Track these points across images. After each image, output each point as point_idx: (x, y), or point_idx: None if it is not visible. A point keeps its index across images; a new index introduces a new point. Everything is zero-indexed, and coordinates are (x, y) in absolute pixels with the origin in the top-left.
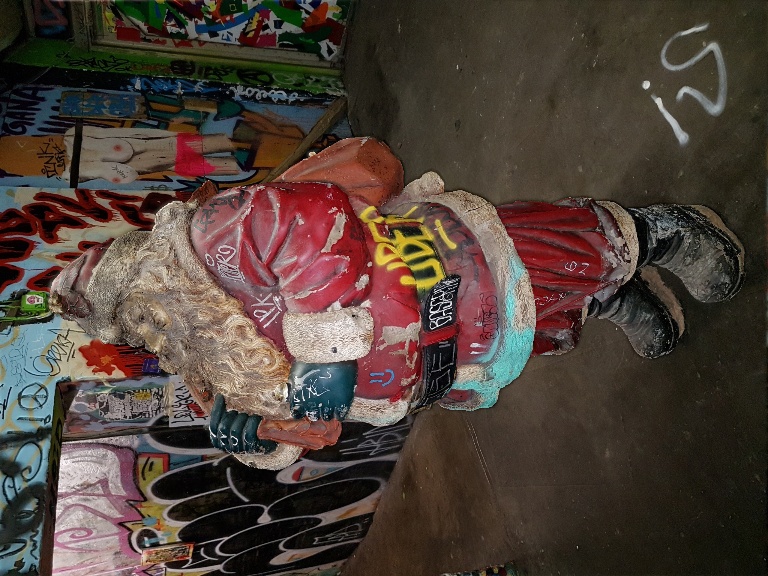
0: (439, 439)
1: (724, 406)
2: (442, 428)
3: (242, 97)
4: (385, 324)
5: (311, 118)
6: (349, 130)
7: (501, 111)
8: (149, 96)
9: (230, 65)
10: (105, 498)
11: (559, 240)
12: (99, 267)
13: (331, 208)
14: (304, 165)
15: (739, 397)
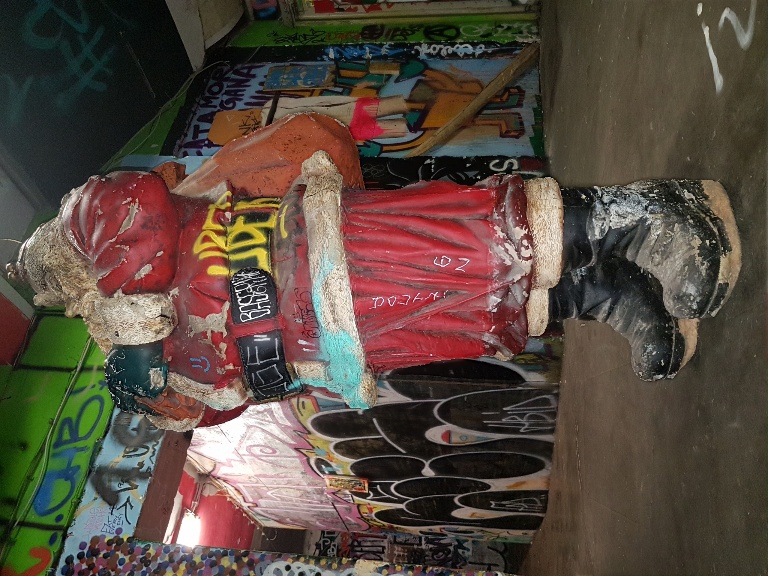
0: (566, 429)
1: (707, 461)
2: (566, 418)
3: (428, 55)
4: (189, 312)
5: (495, 71)
6: (537, 80)
7: (612, 53)
8: (341, 64)
9: (419, 23)
10: (275, 425)
11: (430, 230)
12: (32, 243)
13: (126, 199)
14: (231, 146)
15: (717, 453)
